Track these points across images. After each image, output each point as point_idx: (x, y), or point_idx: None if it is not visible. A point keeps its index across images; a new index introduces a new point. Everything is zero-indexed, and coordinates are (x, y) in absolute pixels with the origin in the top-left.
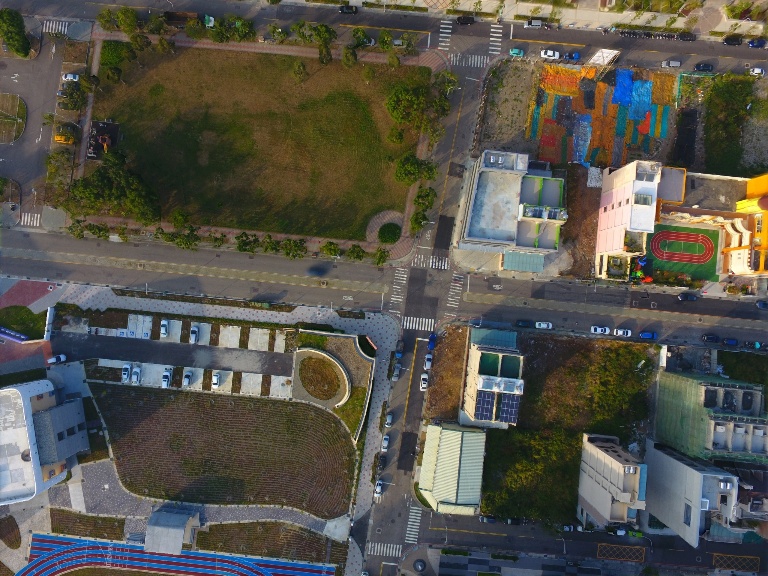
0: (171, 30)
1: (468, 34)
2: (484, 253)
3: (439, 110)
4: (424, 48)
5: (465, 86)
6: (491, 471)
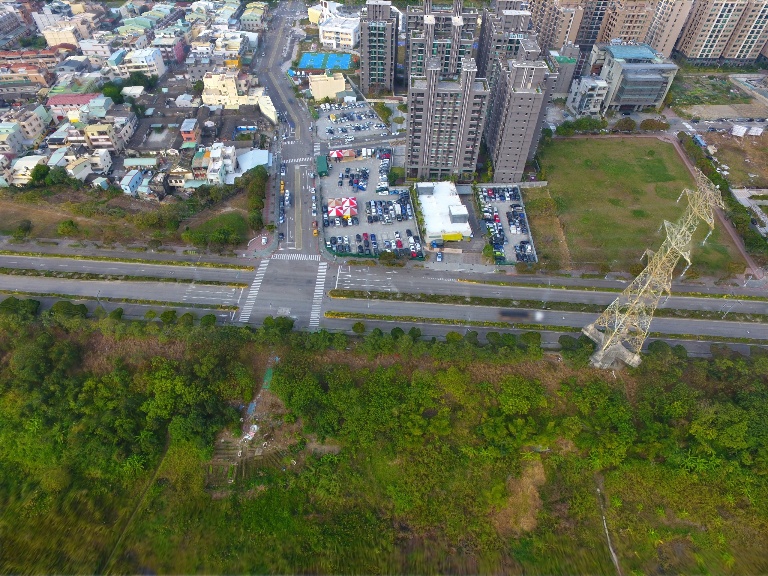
0: None
1: None
2: None
3: None
4: None
5: None
6: None
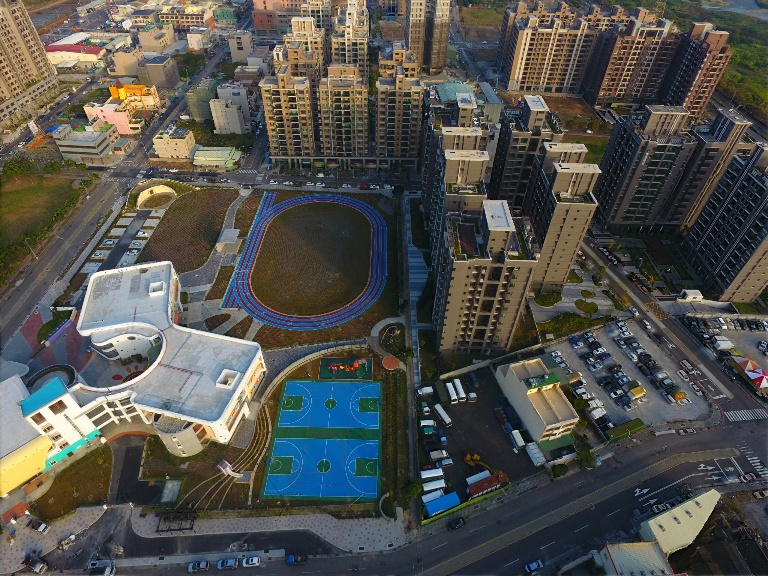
0: None
1: None
2: (114, 158)
3: None
4: None
5: None
6: None
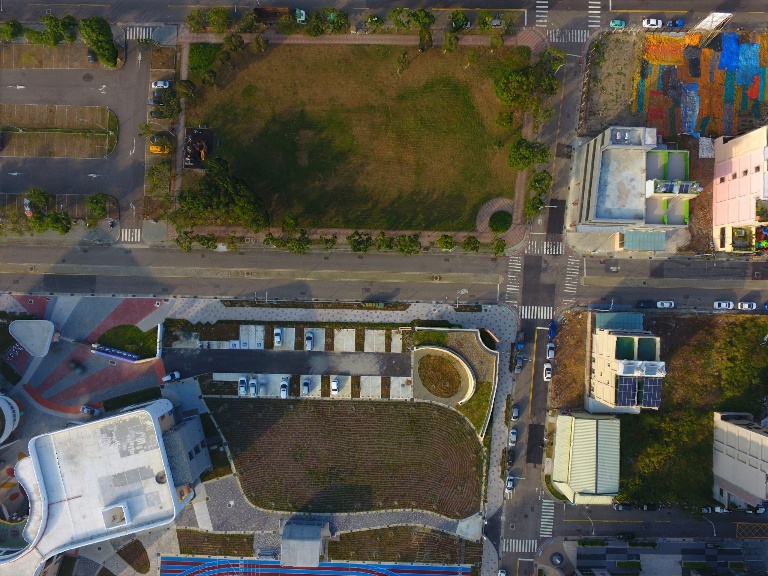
0: (259, 27)
1: (566, 8)
2: (599, 235)
3: (548, 89)
4: (521, 27)
5: (566, 63)
6: (623, 458)
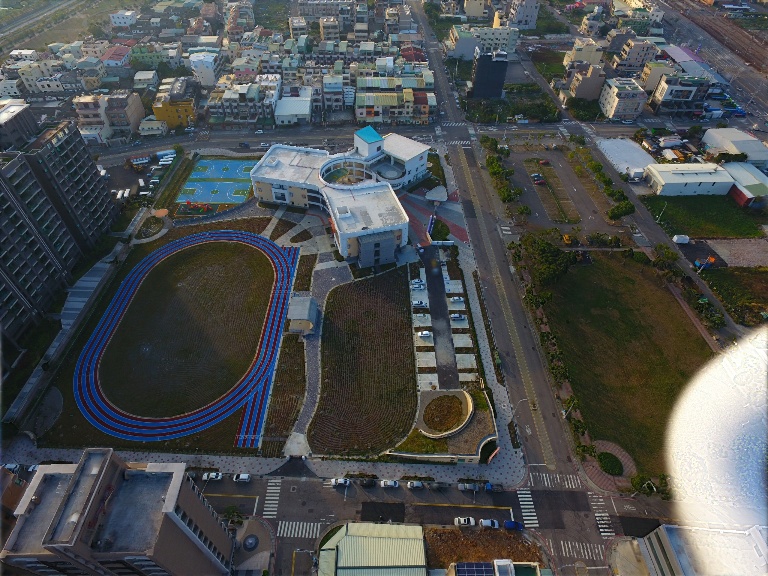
0: (678, 284)
1: None
2: None
3: None
4: None
5: None
6: None
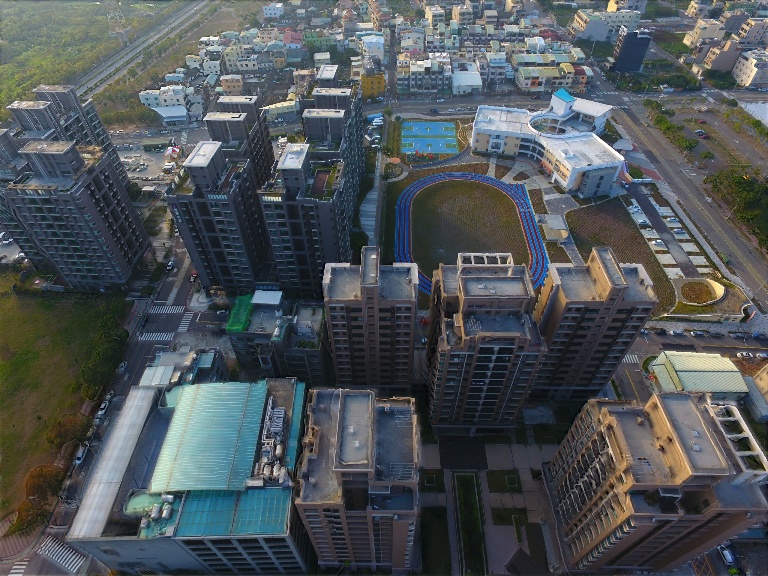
0: None
1: None
2: None
3: None
4: None
5: None
6: None
